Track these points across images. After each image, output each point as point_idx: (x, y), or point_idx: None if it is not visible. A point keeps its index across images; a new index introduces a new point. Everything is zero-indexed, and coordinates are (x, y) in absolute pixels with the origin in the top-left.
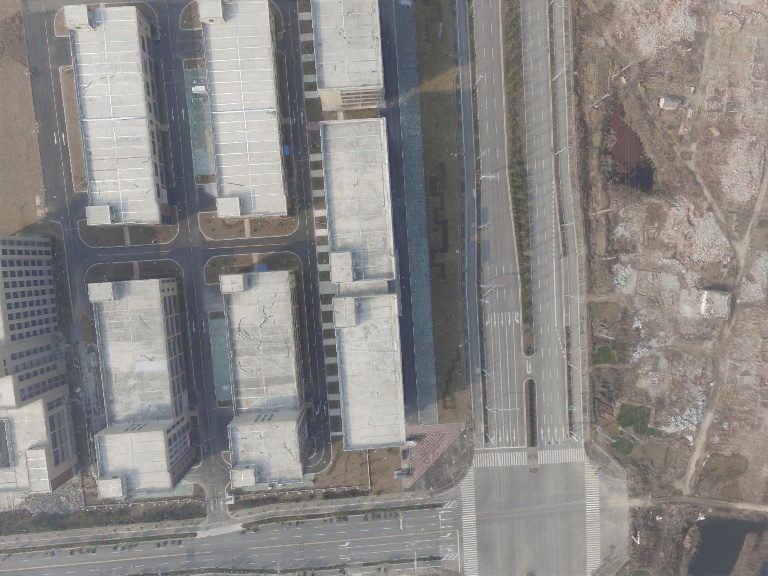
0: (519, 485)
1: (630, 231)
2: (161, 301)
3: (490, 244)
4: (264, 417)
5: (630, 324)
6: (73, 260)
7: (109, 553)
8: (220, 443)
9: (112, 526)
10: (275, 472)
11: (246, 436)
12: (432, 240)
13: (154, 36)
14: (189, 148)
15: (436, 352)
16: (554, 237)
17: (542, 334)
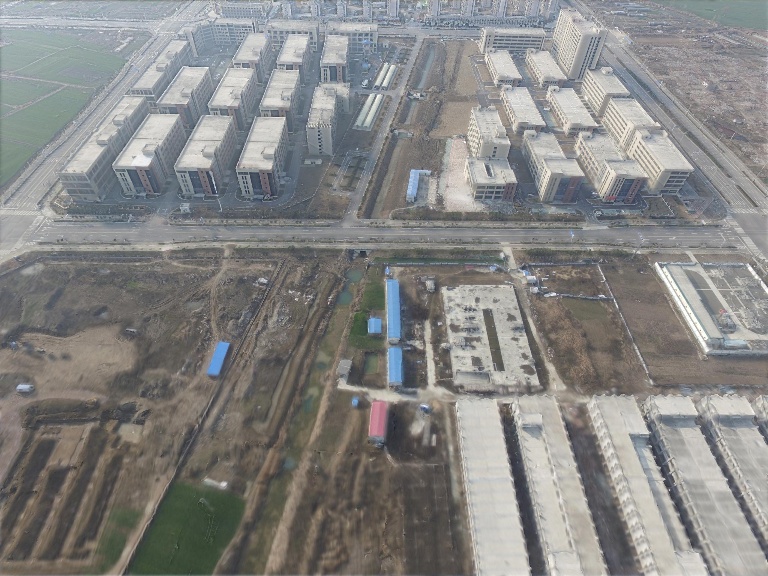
0: (761, 221)
1: None
2: None
3: None
4: None
5: None
6: None
7: None
8: (584, 196)
9: (533, 222)
10: (633, 175)
11: None
12: None
13: None
14: None
15: None
16: None
17: (731, 172)
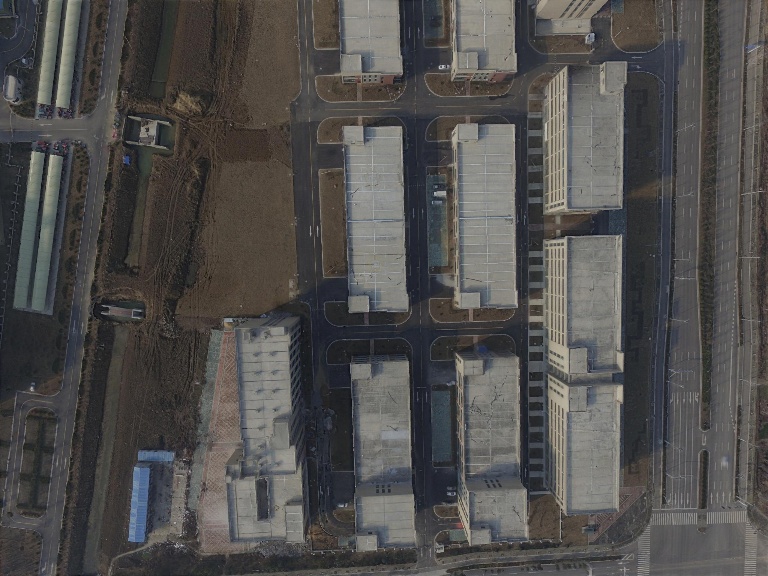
0: (689, 542)
1: None
2: None
3: (678, 333)
4: (492, 483)
5: None
6: (318, 336)
7: None
8: (433, 498)
9: (334, 568)
10: (504, 532)
11: (482, 500)
12: (629, 328)
13: (403, 146)
14: (425, 243)
15: (626, 425)
16: (733, 329)
17: (717, 412)
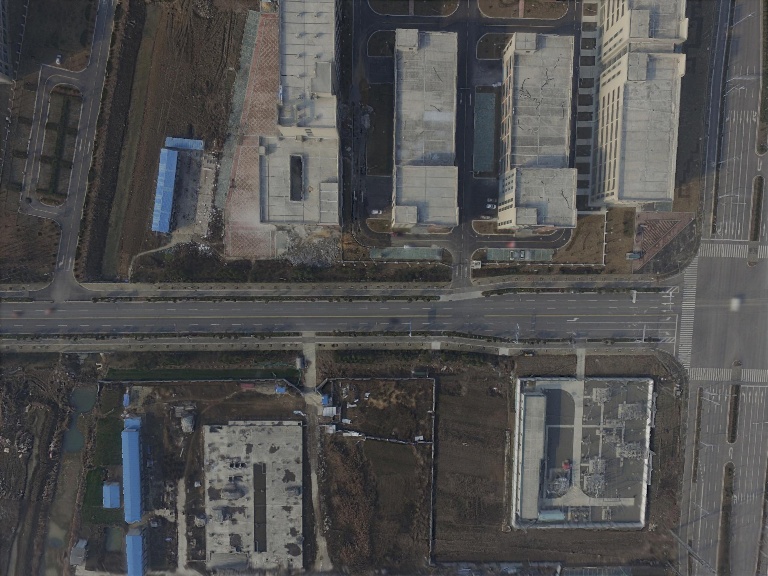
0: (738, 277)
1: None
2: (456, 54)
3: (738, 44)
4: None
5: None
6: (359, 24)
7: (358, 309)
8: (471, 212)
9: (364, 283)
10: (551, 217)
11: (529, 181)
12: None
13: None
14: None
15: (678, 142)
16: None
17: None
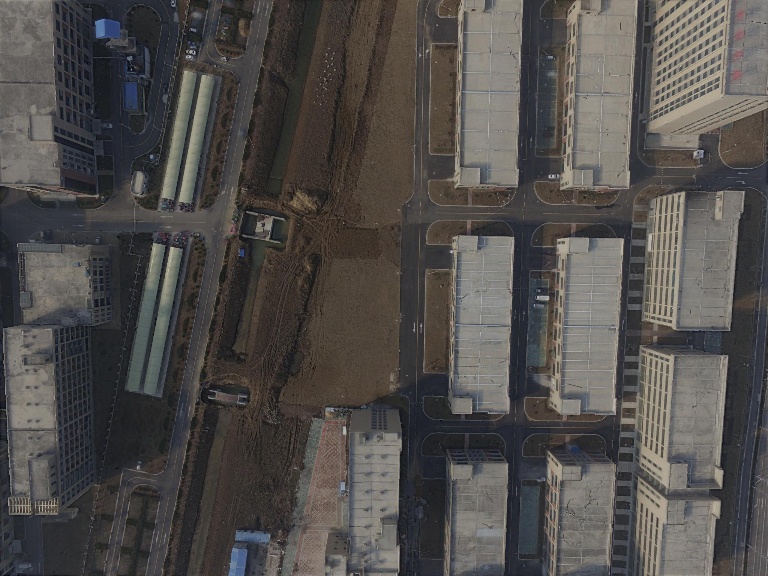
0: None
1: None
2: (507, 481)
3: (767, 441)
4: None
5: None
6: (415, 428)
7: None
8: None
9: None
10: None
11: None
12: None
13: None
14: (525, 343)
15: None
16: None
17: None
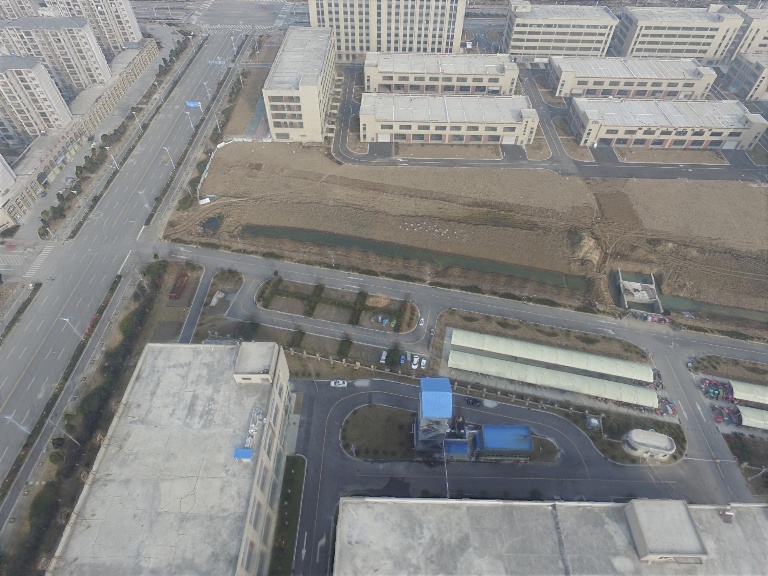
0: None
1: (625, 0)
2: None
3: None
4: None
5: (677, 1)
6: None
7: None
8: None
9: None
10: None
11: None
12: None
13: None
14: None
15: None
16: None
17: None
